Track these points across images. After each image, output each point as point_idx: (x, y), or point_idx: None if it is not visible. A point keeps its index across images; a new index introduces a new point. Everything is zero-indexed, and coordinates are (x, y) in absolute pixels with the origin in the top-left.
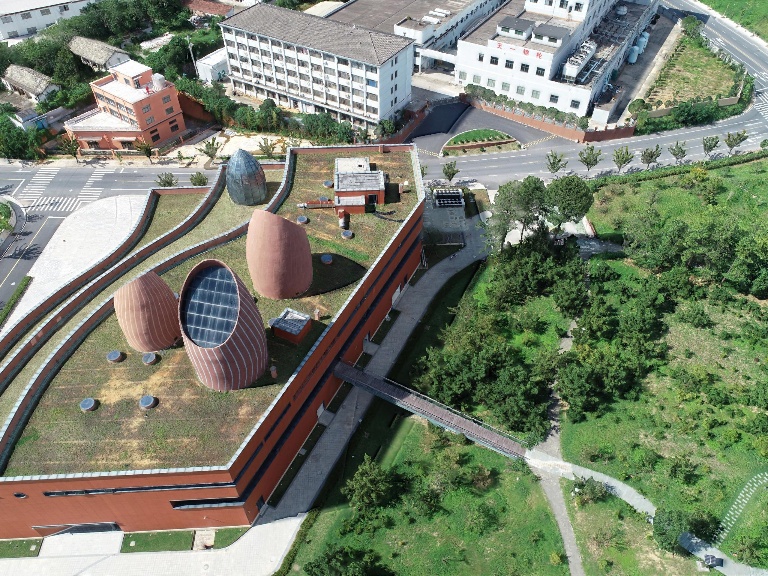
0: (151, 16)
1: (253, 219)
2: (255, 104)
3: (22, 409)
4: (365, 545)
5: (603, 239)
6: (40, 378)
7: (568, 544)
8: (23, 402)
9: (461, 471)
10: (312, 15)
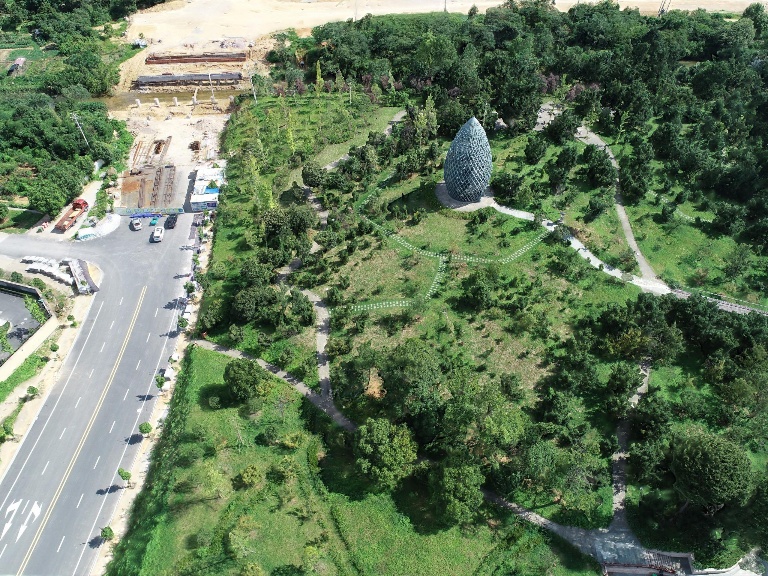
0: None
1: None
2: None
3: None
4: (764, 258)
5: (591, 558)
6: None
7: (635, 246)
8: None
9: (715, 290)
10: None
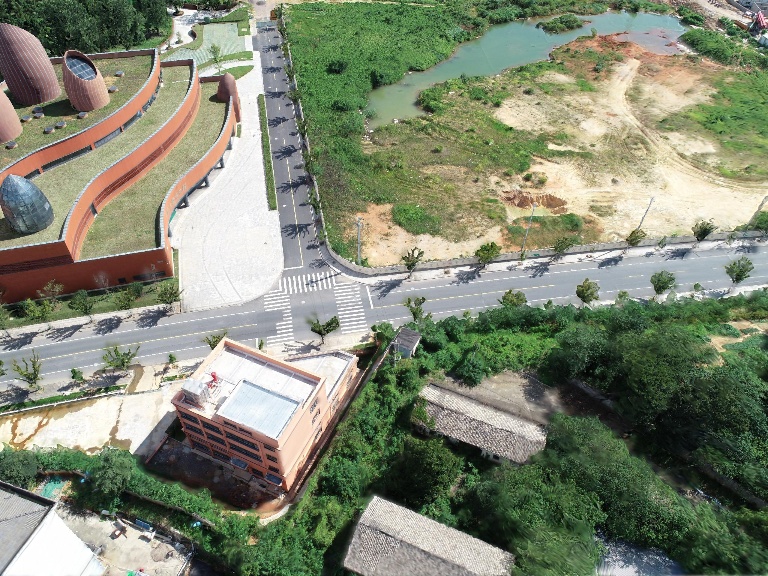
0: None
1: None
2: None
3: None
4: None
5: None
6: None
7: None
8: None
9: None
10: None
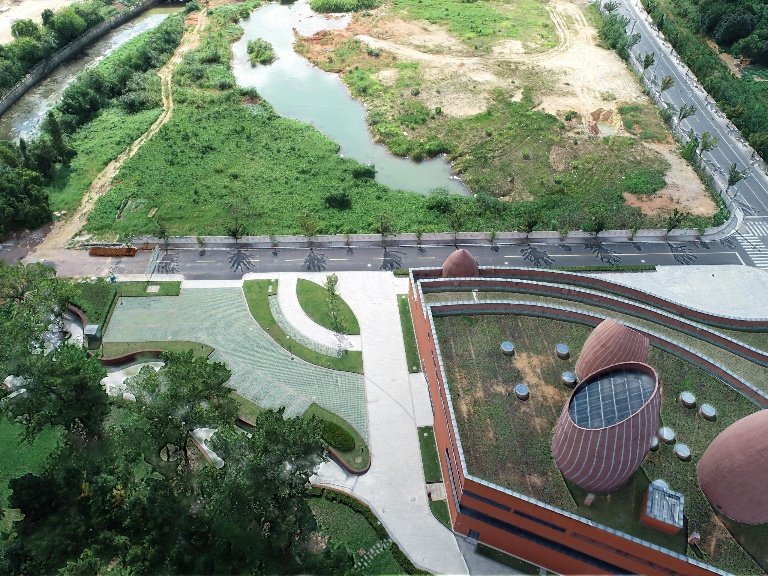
0: None
1: None
2: None
3: (492, 307)
4: None
5: None
6: (523, 307)
7: None
8: (497, 304)
9: None
10: None
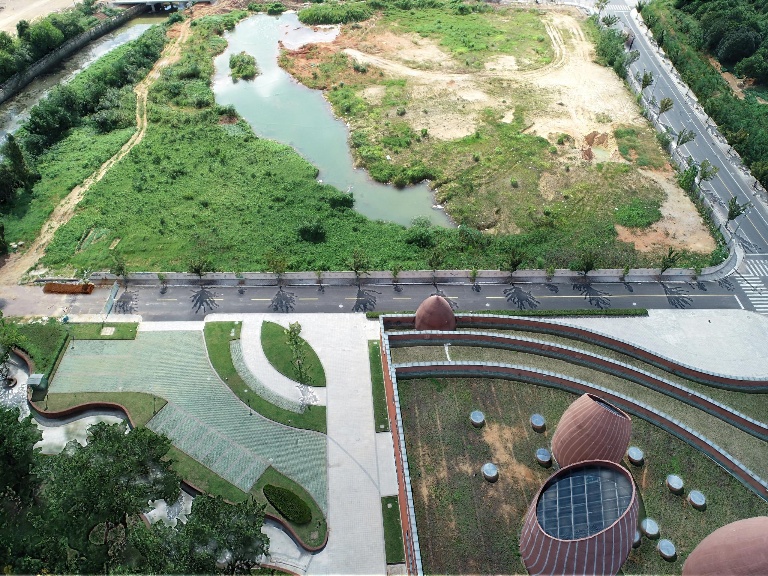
0: None
1: (763, 520)
2: None
3: (463, 368)
4: None
5: None
6: (497, 368)
7: None
8: (469, 366)
9: None
10: None
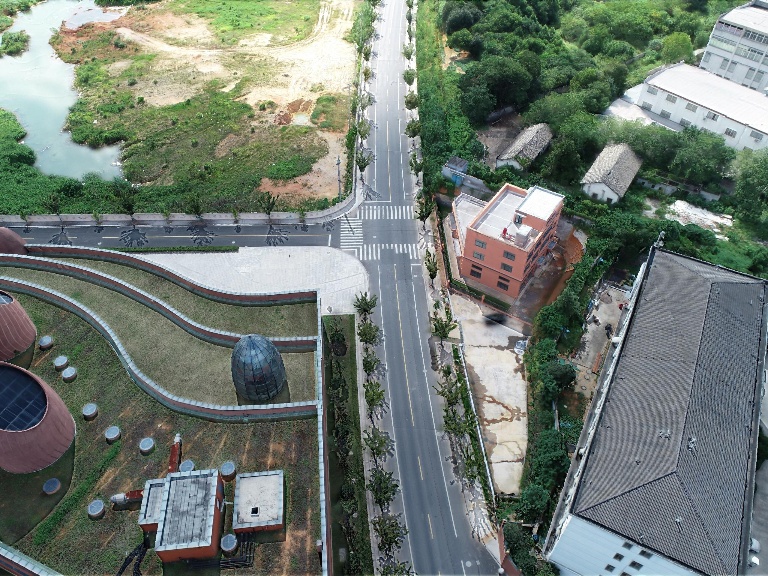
0: (737, 187)
1: None
2: (590, 359)
3: None
4: None
5: None
6: None
7: None
8: None
9: None
10: (762, 366)
